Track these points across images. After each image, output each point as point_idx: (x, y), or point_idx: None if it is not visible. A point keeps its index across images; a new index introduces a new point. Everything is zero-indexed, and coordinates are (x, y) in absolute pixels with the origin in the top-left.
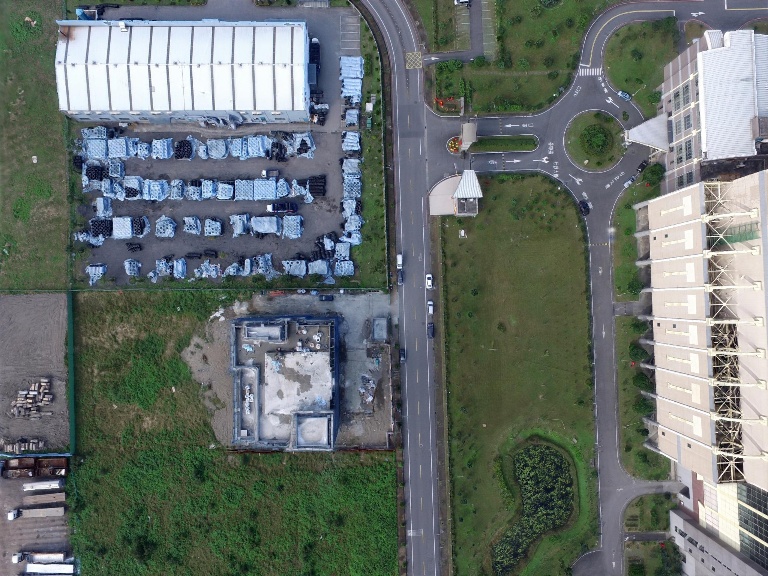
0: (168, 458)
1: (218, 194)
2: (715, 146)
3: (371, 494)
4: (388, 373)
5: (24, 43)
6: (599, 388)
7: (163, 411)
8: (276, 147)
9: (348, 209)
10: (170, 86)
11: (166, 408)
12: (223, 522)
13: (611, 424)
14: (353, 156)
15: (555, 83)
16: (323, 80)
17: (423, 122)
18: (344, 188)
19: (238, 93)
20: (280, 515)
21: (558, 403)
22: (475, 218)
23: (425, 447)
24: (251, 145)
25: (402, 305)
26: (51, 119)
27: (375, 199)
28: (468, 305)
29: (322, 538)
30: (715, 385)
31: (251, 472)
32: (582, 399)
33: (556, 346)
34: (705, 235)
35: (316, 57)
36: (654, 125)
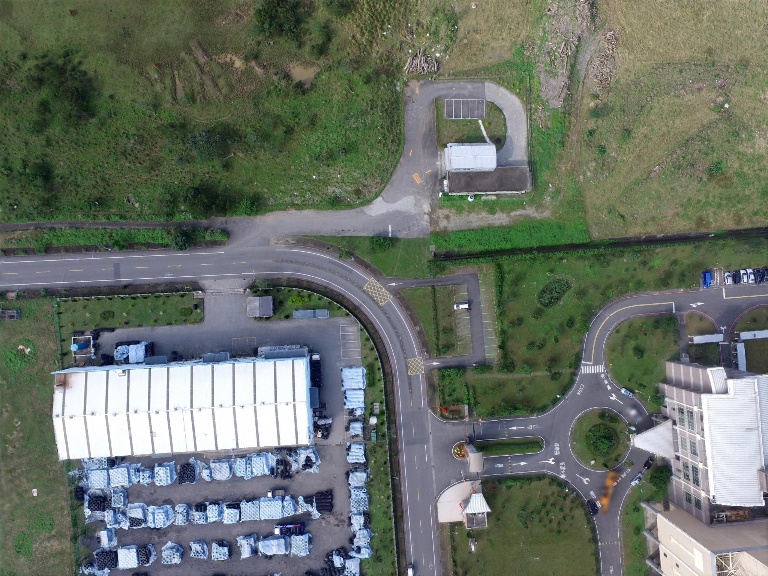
0: None
1: (224, 519)
2: (723, 492)
3: None
4: None
5: (18, 373)
6: None
7: None
8: (281, 465)
9: (356, 524)
10: (171, 430)
11: None
12: None
13: None
14: (359, 468)
15: (558, 383)
16: (325, 392)
17: (428, 428)
18: (351, 504)
19: (241, 432)
20: None
21: None
22: None
23: None
24: (255, 466)
25: None
26: (50, 450)
27: (383, 511)
28: None
29: None
30: None
31: None
32: None
33: None
34: None
35: (317, 376)
36: (659, 433)
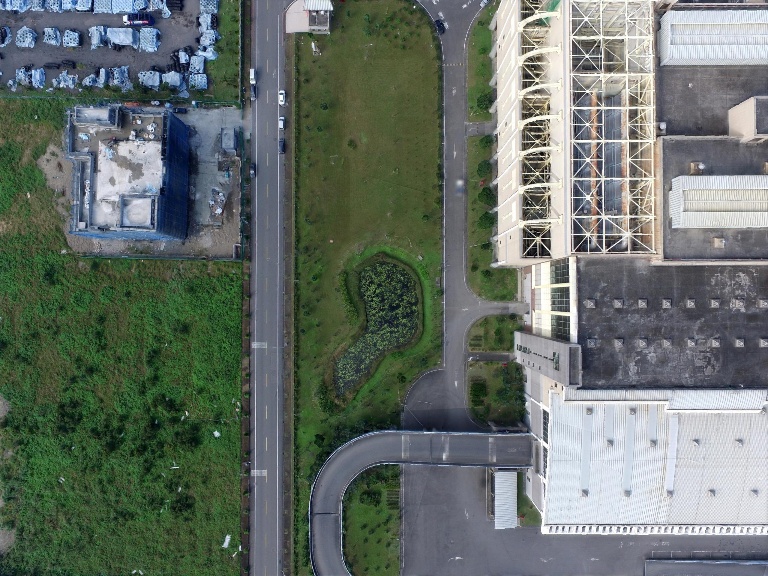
0: (20, 261)
1: (77, 5)
2: None
3: (216, 304)
4: (238, 187)
5: None
6: (448, 208)
7: (18, 216)
8: None
9: (204, 23)
10: None
11: (21, 213)
12: (71, 325)
13: (459, 244)
14: None
15: None
16: None
17: None
18: (200, 2)
19: None
20: (127, 321)
21: (406, 221)
22: (330, 36)
23: (272, 261)
24: None
25: (255, 121)
26: None
27: (231, 15)
28: (320, 122)
29: (167, 345)
30: (521, 157)
31: (100, 278)
32: (430, 218)
33: (406, 164)
34: (519, 9)
35: None
36: None
